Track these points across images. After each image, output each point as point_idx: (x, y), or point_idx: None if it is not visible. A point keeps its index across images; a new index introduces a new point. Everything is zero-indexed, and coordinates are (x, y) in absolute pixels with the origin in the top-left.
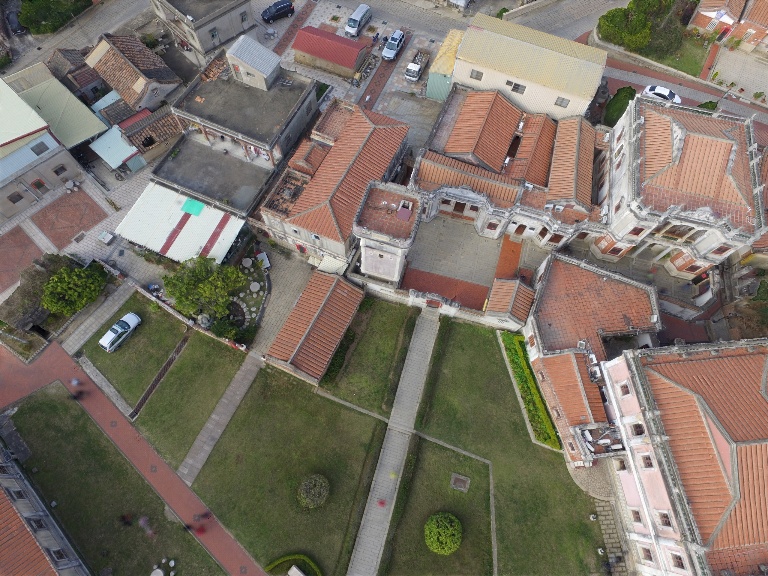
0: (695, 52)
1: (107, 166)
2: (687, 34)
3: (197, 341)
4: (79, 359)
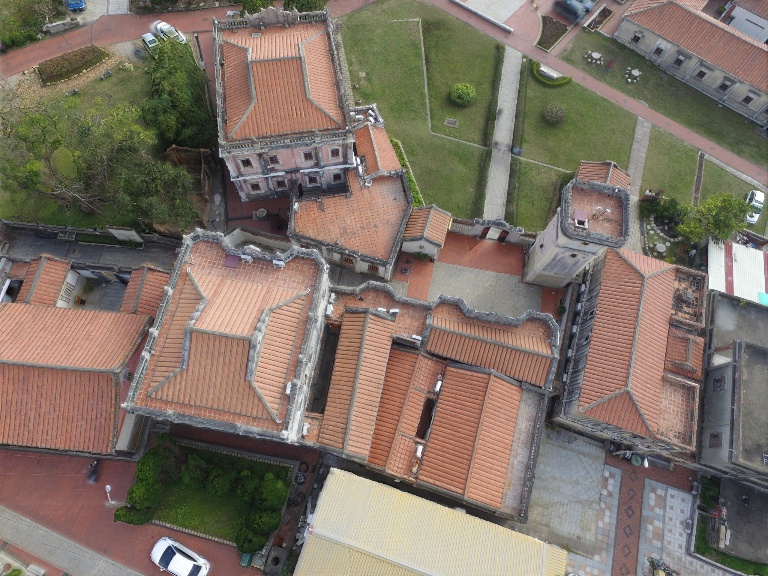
0: None
1: None
2: None
3: None
4: None
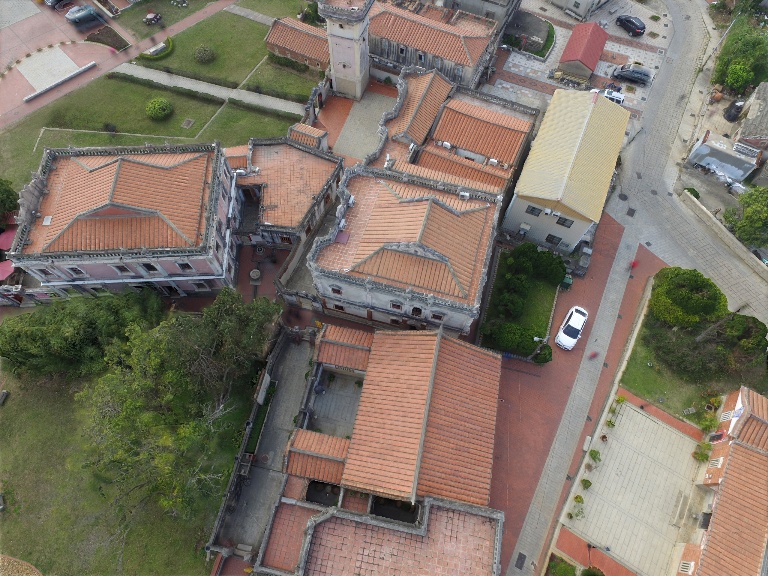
0: (674, 398)
1: None
2: (709, 392)
3: None
4: None
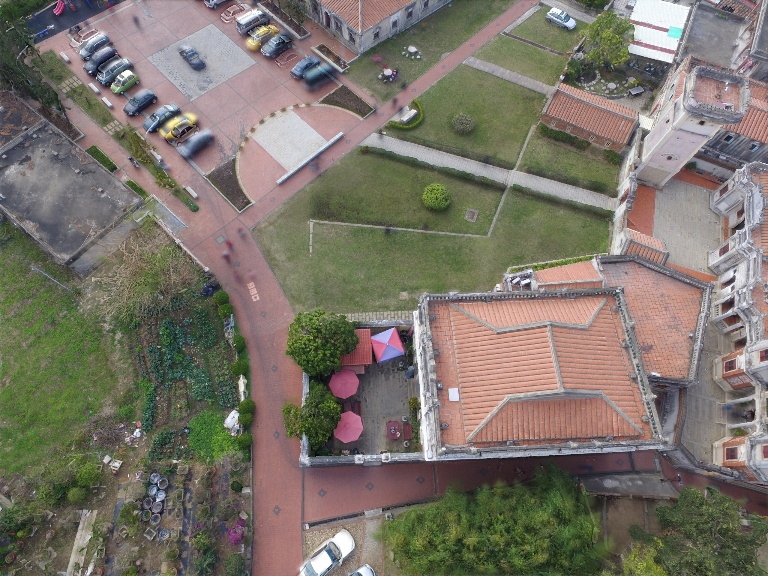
0: None
1: (694, 0)
2: None
3: (561, 60)
4: (538, 5)
